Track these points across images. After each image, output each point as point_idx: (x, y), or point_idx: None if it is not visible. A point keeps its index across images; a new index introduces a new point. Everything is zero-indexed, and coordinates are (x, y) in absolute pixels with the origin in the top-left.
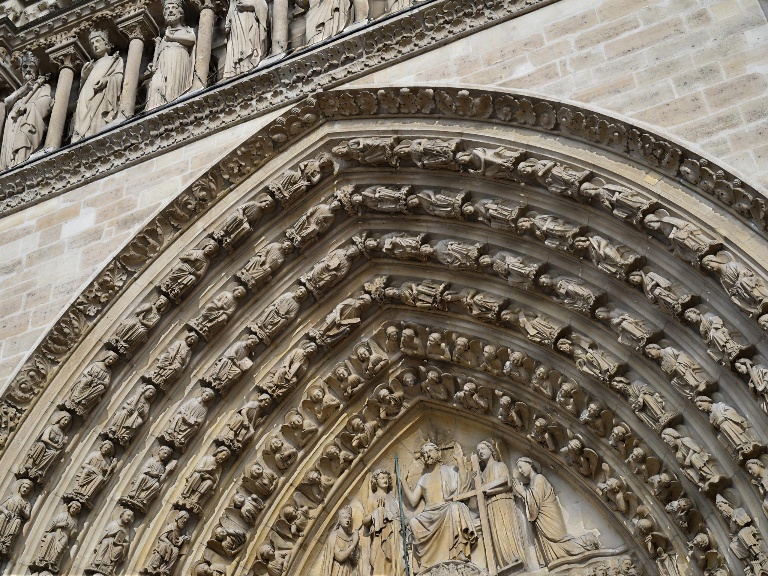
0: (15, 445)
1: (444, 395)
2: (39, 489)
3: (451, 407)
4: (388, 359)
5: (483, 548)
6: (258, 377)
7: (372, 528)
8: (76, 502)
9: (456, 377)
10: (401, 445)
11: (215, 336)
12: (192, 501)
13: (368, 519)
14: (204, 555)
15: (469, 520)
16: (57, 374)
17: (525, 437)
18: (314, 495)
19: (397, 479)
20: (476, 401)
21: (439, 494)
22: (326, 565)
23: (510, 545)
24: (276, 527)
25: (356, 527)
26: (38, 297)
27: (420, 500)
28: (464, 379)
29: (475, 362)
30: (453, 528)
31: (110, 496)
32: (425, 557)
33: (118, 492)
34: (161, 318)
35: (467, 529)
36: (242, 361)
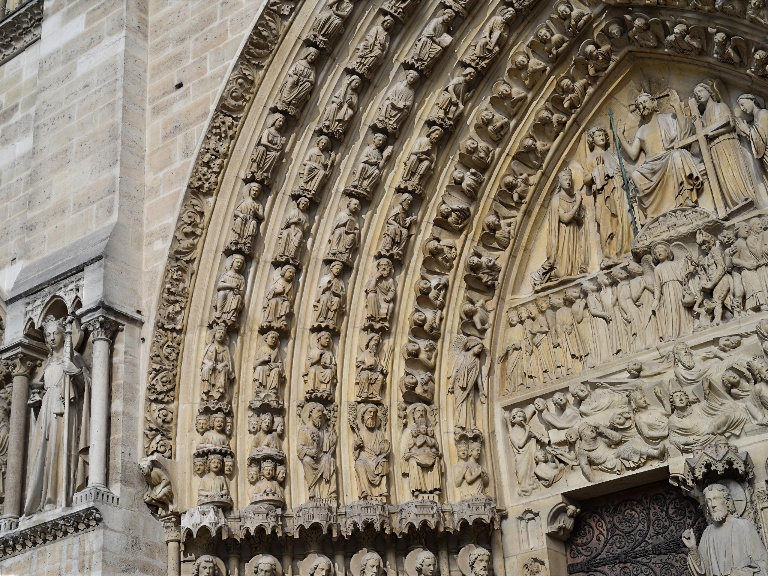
0: (238, 152)
1: (654, 42)
2: (267, 190)
3: (662, 53)
4: (590, 13)
5: (710, 192)
6: (460, 52)
7: (594, 186)
8: (304, 198)
9: (664, 21)
10: (614, 100)
11: (410, 16)
12: (413, 183)
13: (589, 178)
14: (432, 233)
15: (693, 166)
16: (264, 78)
17: (744, 73)
18: (532, 162)
19: (614, 135)
20: (688, 43)
21: (659, 144)
22: (552, 228)
23: (738, 185)
24: (498, 198)
25: (578, 188)
26: (232, 4)
27: (640, 153)
28: (673, 22)
29: (683, 2)
30: (677, 176)
31: (334, 188)
32: (651, 208)
33: (341, 184)
34: (354, 6)
35: (691, 175)
36: (441, 38)
